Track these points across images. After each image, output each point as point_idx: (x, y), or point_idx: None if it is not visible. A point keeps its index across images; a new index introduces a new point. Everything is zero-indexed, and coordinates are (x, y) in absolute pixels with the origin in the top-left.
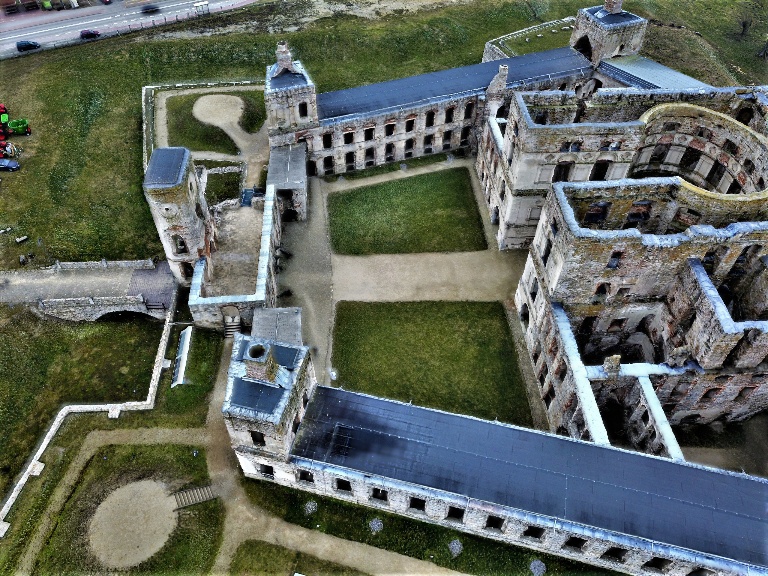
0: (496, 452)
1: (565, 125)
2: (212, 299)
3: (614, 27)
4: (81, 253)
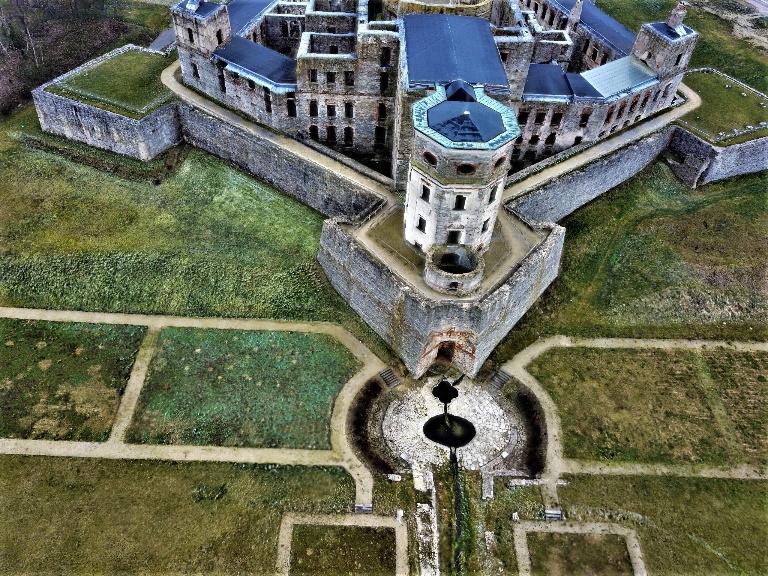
0: None
1: None
2: None
3: (649, 28)
4: None
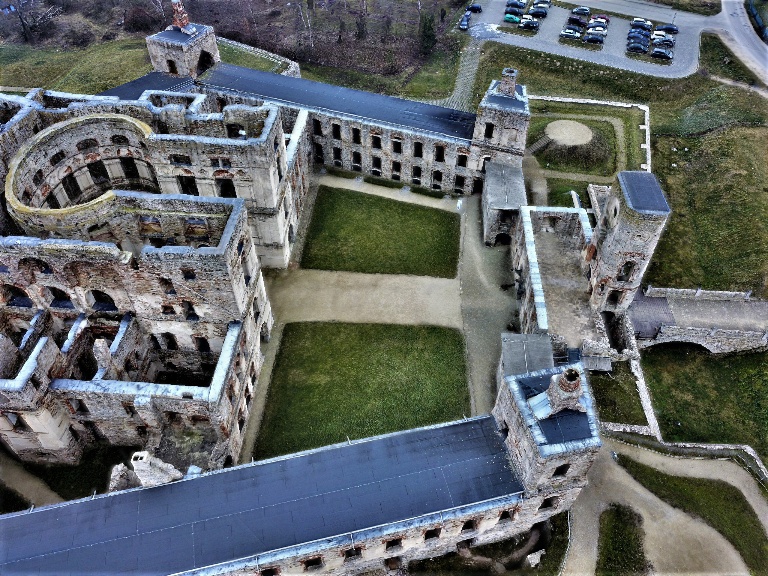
0: (368, 106)
1: (201, 198)
2: (566, 210)
3: None
4: (762, 374)
